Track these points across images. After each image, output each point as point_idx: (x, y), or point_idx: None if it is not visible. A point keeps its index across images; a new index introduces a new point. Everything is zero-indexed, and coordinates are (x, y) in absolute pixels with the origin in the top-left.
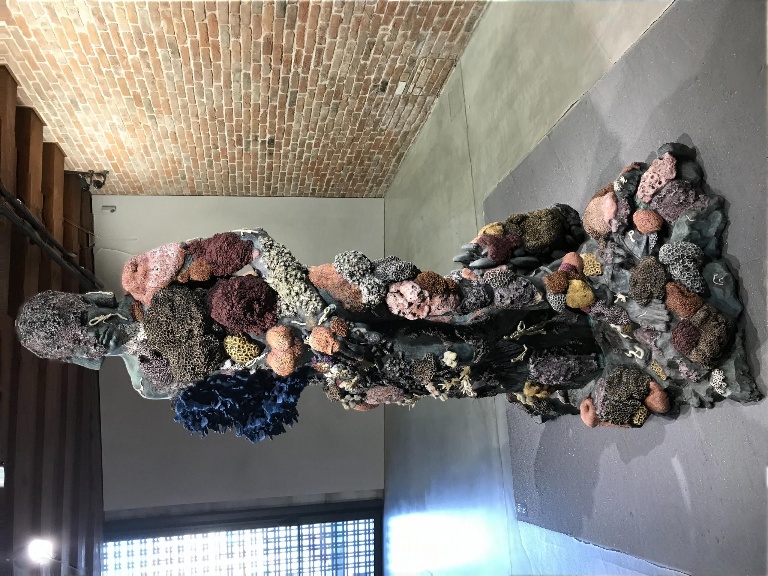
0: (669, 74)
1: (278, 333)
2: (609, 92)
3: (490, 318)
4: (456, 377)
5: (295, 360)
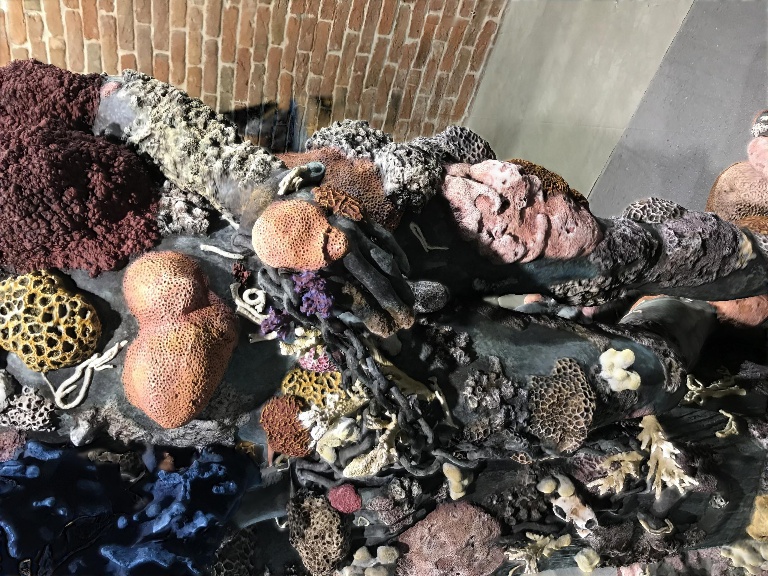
0: (756, 13)
1: (159, 262)
2: (655, 115)
3: (652, 322)
4: (632, 446)
5: (210, 348)
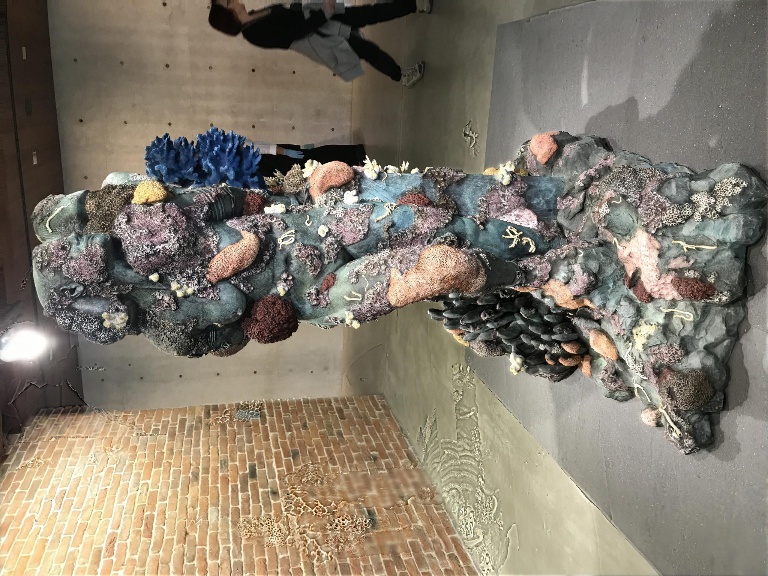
0: None
1: None
2: (545, 430)
3: None
4: None
5: None
